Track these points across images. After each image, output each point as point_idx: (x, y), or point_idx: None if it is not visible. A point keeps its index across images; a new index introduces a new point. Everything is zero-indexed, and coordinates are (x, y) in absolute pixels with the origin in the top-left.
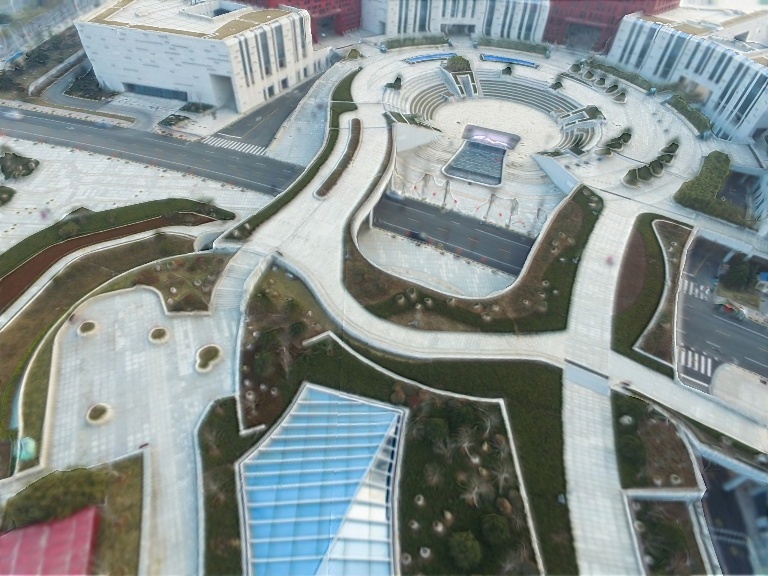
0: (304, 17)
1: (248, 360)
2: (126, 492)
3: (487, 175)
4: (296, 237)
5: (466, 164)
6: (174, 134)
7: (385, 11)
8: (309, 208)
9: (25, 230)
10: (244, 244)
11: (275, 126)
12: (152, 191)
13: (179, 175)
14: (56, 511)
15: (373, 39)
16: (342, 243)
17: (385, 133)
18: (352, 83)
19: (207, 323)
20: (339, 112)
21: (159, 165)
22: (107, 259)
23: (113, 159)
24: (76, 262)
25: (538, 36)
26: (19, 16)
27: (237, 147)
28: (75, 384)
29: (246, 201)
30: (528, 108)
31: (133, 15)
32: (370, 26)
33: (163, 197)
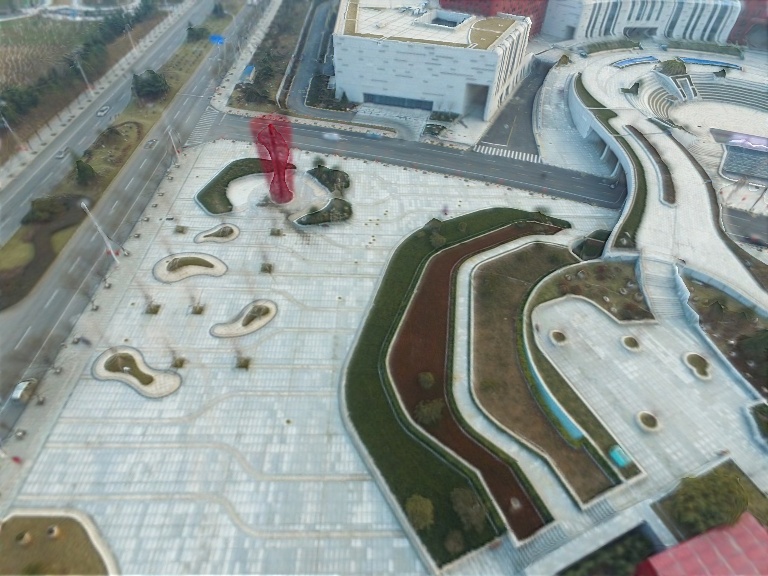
0: (529, 25)
1: (745, 368)
2: (752, 498)
3: (767, 179)
4: (680, 245)
5: (739, 168)
6: (444, 143)
7: (578, 16)
8: (668, 216)
9: (386, 241)
10: (642, 253)
11: (528, 133)
12: (470, 201)
13: (483, 184)
14: (732, 517)
15: (563, 44)
16: (730, 250)
17: (668, 139)
18: (586, 89)
19: (663, 331)
20: (605, 119)
21: (456, 175)
22: (507, 269)
23: (410, 169)
24: (479, 272)
25: (723, 37)
26: (213, 29)
27: (511, 155)
28: (596, 393)
29: (565, 209)
30: (754, 110)
31: (372, 27)
32: (553, 31)
33: (485, 206)
